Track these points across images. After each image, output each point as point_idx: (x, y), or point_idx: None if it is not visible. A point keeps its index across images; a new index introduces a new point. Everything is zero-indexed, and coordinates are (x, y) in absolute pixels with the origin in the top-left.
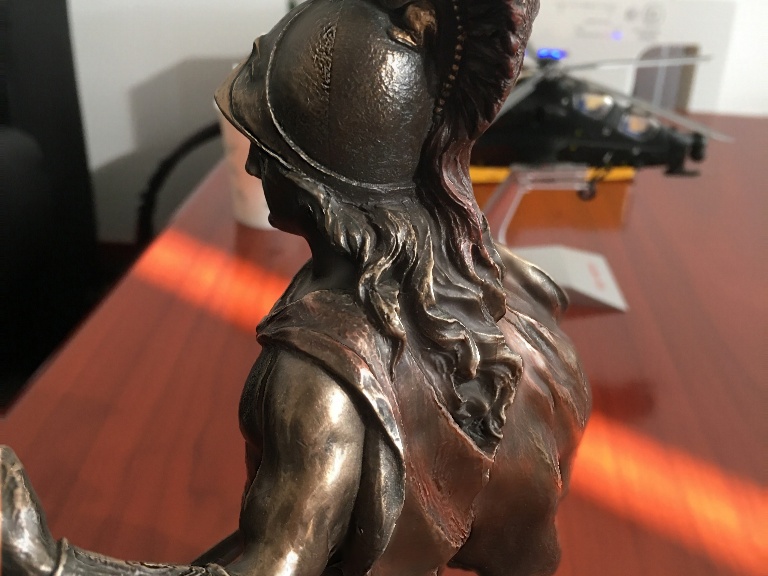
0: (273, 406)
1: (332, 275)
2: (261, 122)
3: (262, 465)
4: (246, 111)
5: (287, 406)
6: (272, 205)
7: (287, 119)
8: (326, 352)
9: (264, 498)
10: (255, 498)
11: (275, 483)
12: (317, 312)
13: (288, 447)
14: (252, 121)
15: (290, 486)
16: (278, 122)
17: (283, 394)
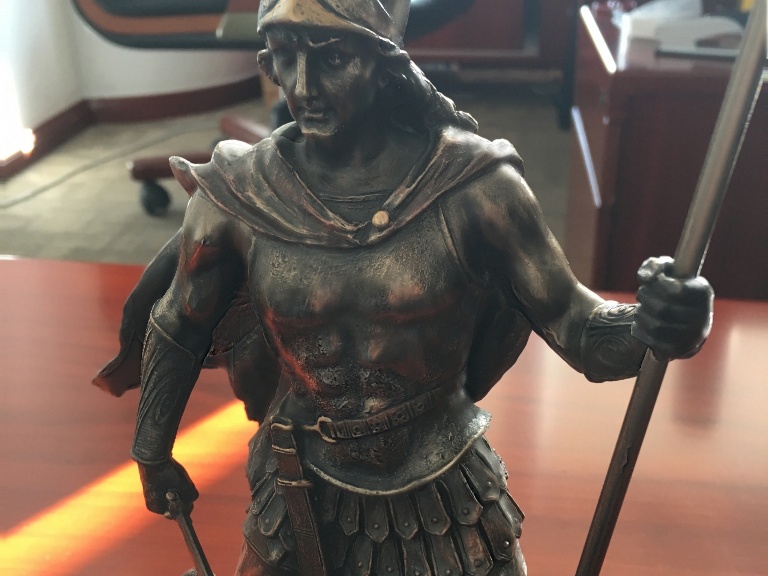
0: (521, 205)
1: (391, 143)
2: (376, 13)
3: (532, 254)
4: (360, 10)
5: (527, 195)
6: (354, 106)
7: (389, 2)
8: (508, 148)
9: (554, 264)
10: (551, 271)
11: (550, 250)
12: (465, 141)
13: (541, 220)
14: (369, 16)
15: (554, 243)
16: (384, 8)
17: (520, 191)
